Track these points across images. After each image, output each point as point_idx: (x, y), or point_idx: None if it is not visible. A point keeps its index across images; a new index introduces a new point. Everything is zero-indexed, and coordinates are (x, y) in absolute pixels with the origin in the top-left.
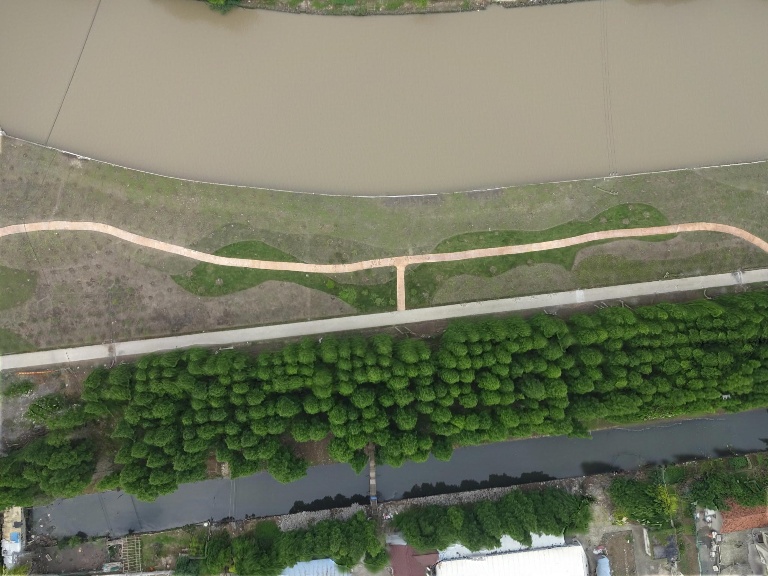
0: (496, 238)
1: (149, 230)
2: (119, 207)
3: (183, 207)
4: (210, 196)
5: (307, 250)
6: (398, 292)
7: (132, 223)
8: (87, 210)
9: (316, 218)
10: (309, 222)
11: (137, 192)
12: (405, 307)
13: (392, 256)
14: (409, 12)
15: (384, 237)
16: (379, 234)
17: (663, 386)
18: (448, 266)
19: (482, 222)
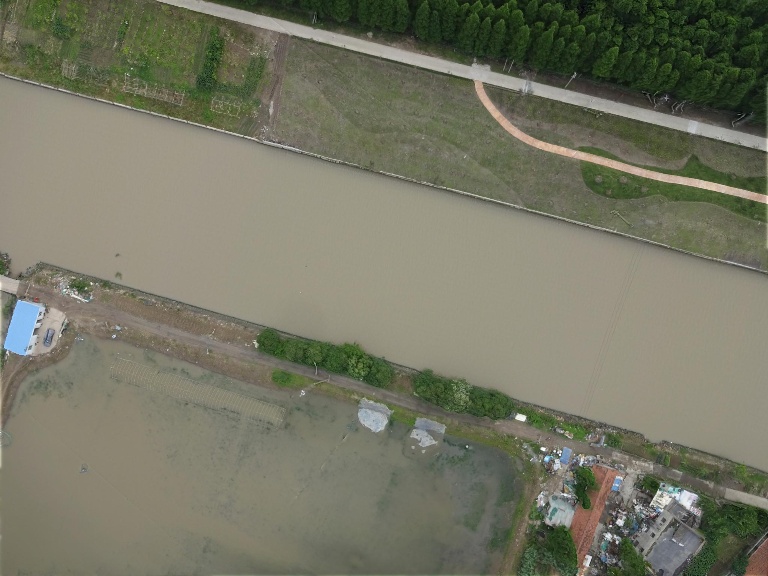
0: (759, 212)
1: None
2: None
3: None
4: None
5: None
6: None
7: None
8: None
9: None
10: None
11: None
12: None
13: None
14: None
15: None
16: None
17: (694, 2)
18: None
19: (762, 233)
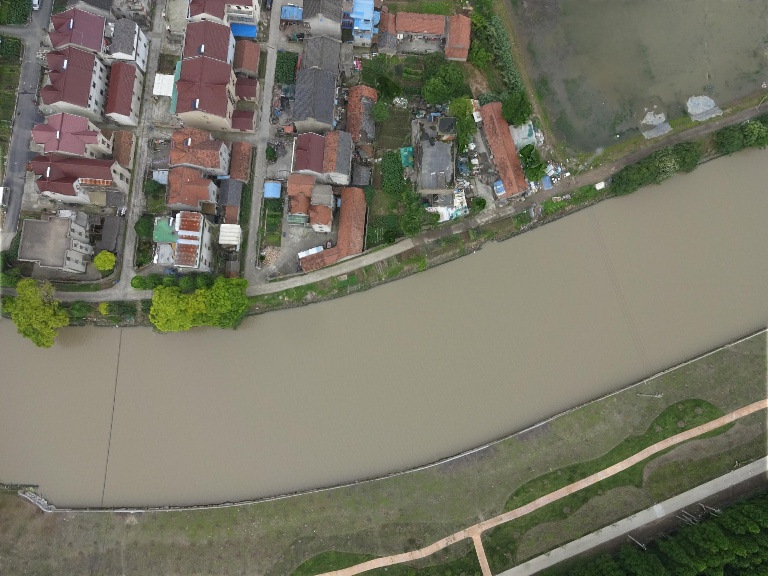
0: (560, 478)
1: (220, 571)
2: (184, 555)
3: (246, 535)
4: (270, 515)
5: (379, 543)
6: (480, 560)
7: (201, 569)
8: (154, 568)
9: (379, 507)
10: (373, 514)
11: (198, 533)
12: (491, 573)
13: (464, 528)
14: (410, 273)
15: (451, 509)
16: (445, 507)
17: None
18: (522, 521)
19: (541, 464)
